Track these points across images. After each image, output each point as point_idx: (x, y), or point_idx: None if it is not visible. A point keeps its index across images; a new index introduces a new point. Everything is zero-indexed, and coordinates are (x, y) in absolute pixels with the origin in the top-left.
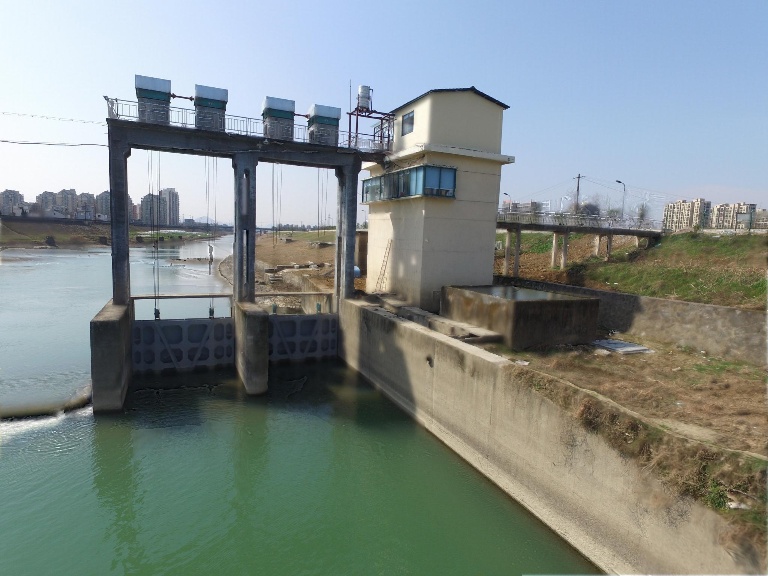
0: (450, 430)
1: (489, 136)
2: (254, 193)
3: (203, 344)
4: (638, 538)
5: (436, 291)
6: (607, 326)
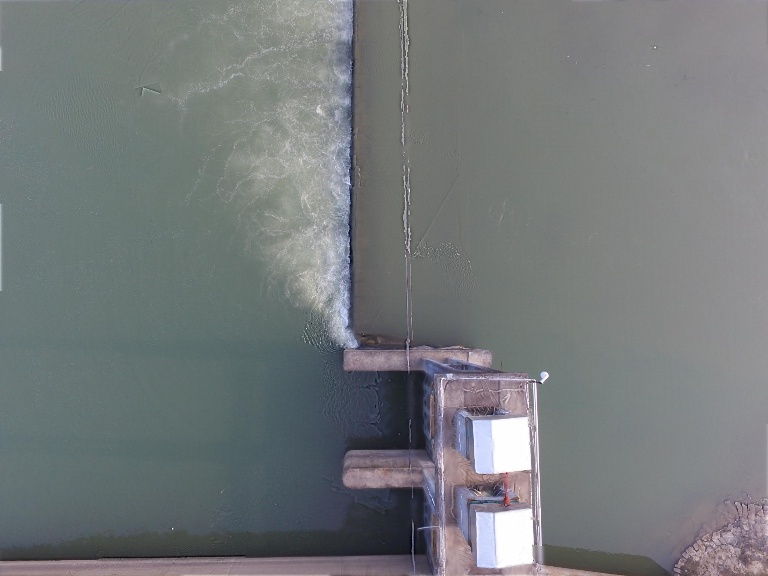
0: (211, 562)
1: None
2: None
3: (426, 426)
4: (74, 570)
5: None
6: None
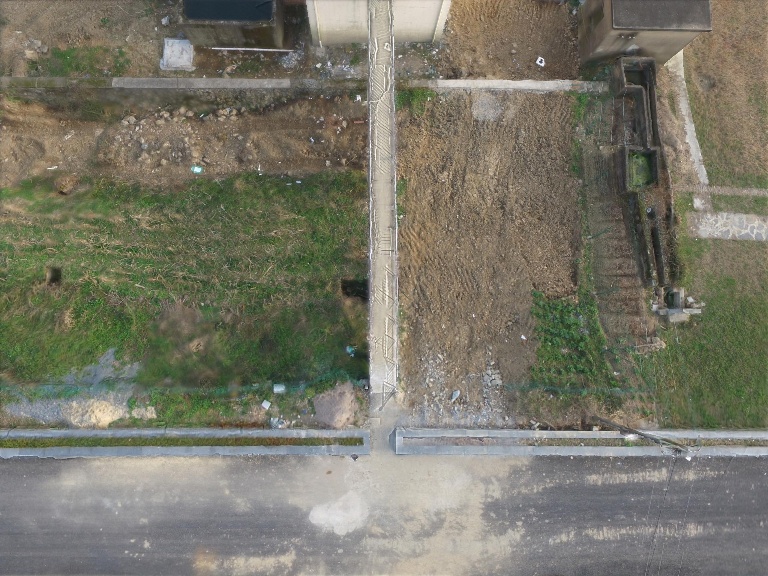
0: None
1: None
2: None
3: None
4: None
5: None
6: None
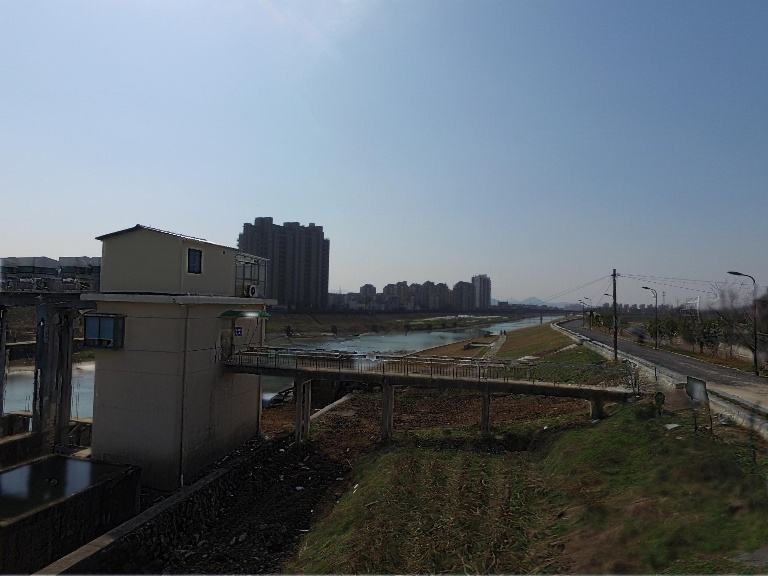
0: None
1: (168, 274)
2: (47, 338)
3: None
4: None
5: (107, 454)
6: None
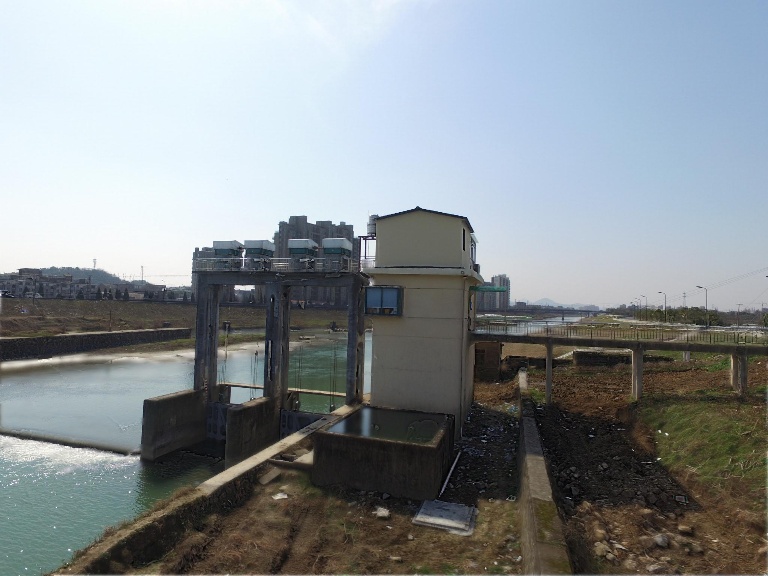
0: None
1: (446, 250)
2: (277, 312)
3: None
4: None
5: None
6: (518, 489)
